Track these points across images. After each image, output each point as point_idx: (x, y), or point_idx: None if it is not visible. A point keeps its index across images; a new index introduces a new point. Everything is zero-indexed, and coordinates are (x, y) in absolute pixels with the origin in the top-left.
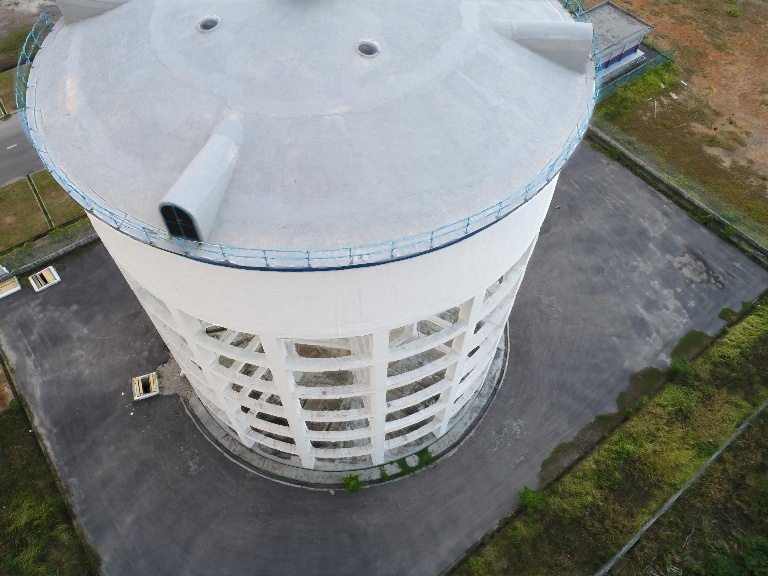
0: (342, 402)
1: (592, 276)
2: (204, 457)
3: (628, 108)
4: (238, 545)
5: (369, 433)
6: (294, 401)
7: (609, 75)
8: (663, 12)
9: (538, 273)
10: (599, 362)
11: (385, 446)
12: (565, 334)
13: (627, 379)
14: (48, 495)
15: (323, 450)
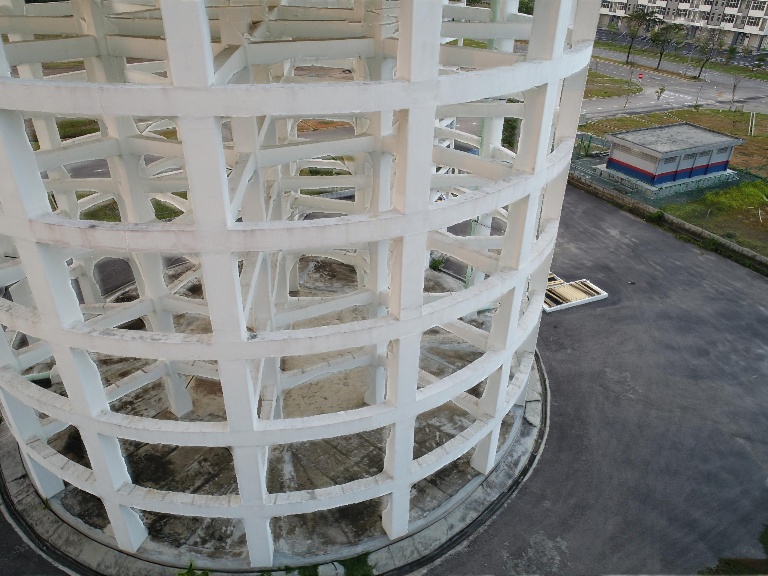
0: None
1: (690, 357)
2: None
3: (723, 211)
4: None
5: (220, 431)
6: (43, 261)
7: (694, 185)
8: (754, 154)
9: (601, 343)
10: (716, 470)
11: (267, 502)
12: (648, 422)
13: None
14: None
15: (145, 489)
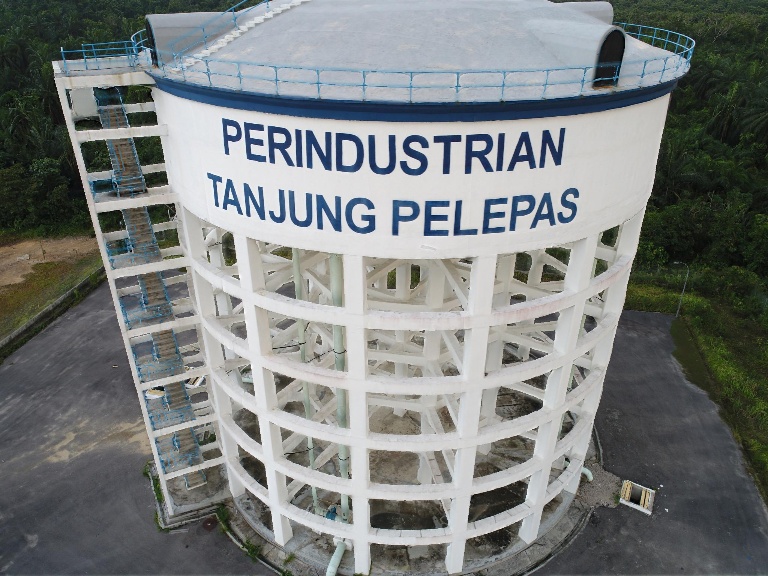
0: None
1: None
2: (603, 413)
3: None
4: None
5: None
6: None
7: None
8: None
9: None
10: None
11: None
12: None
13: (284, 285)
14: None
15: None
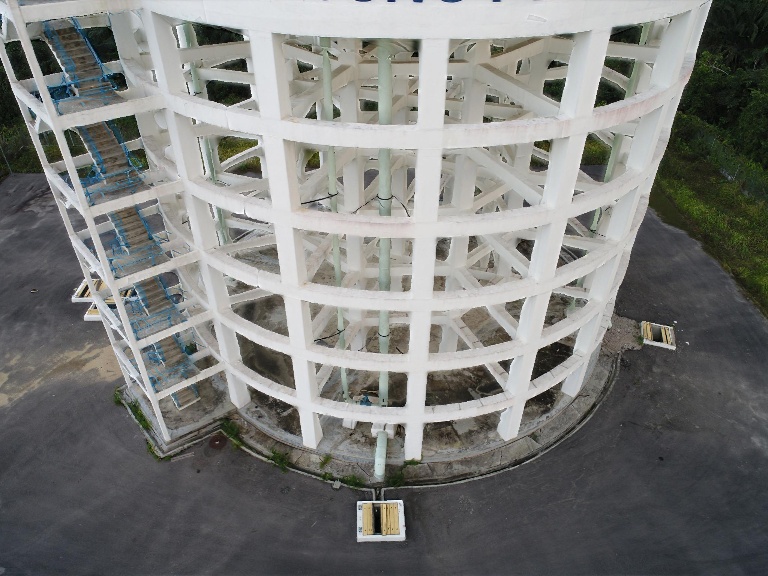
0: (450, 238)
1: None
2: None
3: None
4: (582, 217)
5: None
6: None
7: None
8: None
9: None
10: None
11: None
12: None
13: None
14: (766, 294)
15: None
